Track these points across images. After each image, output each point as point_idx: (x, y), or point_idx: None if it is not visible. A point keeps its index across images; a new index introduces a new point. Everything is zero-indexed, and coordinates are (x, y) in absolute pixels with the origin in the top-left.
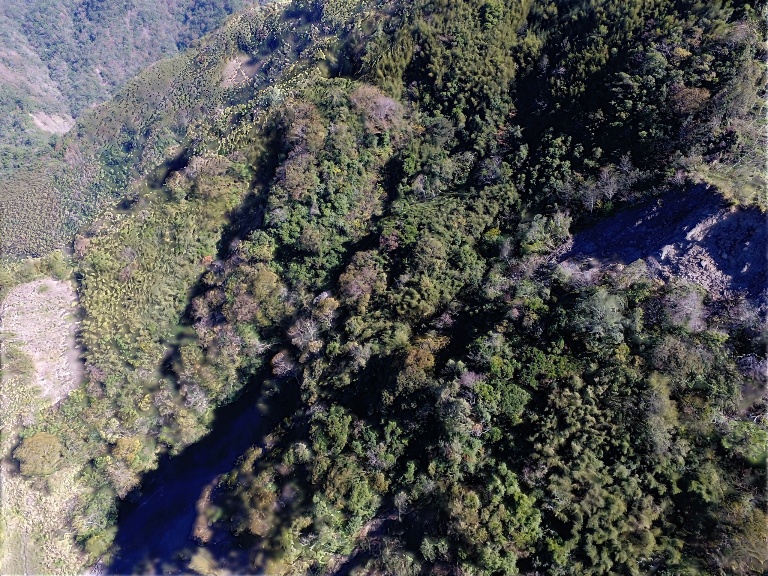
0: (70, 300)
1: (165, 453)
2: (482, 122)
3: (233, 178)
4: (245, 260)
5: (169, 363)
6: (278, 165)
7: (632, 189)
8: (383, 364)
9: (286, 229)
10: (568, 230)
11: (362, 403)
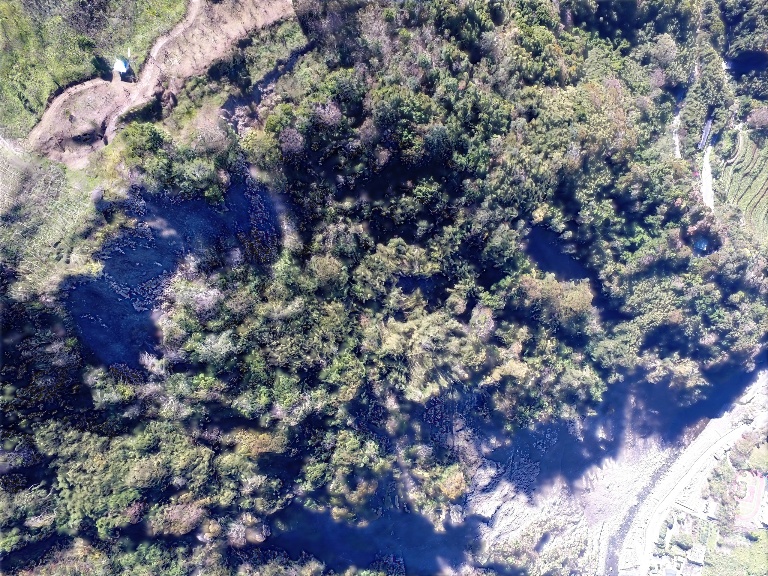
0: None
1: None
2: None
3: None
4: None
5: None
6: None
7: (65, 336)
8: None
9: None
10: None
11: (293, 465)
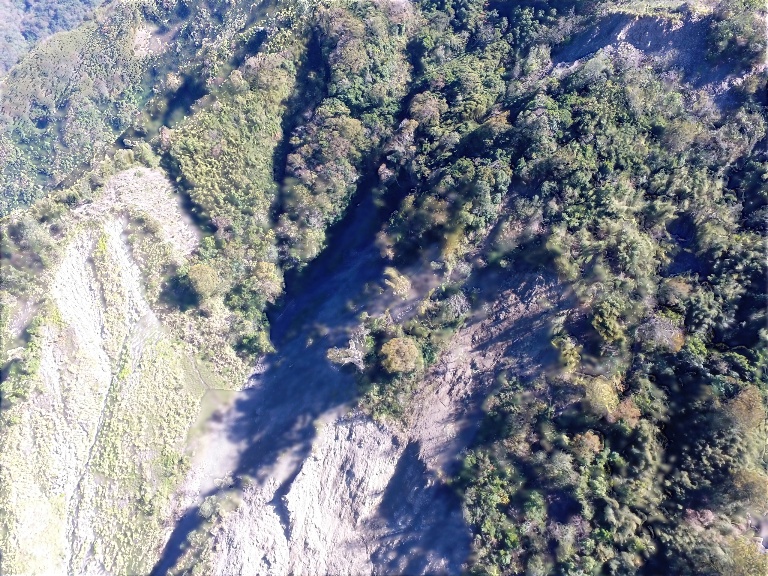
0: (167, 181)
1: (287, 277)
2: (468, 12)
3: (286, 71)
4: (331, 115)
5: (273, 211)
6: (322, 57)
7: (581, 25)
8: (470, 139)
9: (353, 93)
10: (550, 55)
11: None
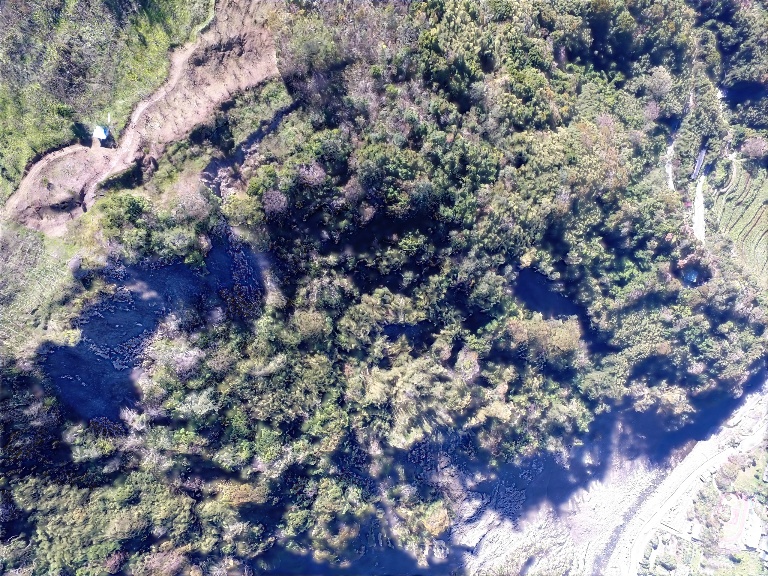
0: None
1: None
2: None
3: None
4: None
5: None
6: None
7: (43, 396)
8: None
9: None
10: None
11: (275, 511)
